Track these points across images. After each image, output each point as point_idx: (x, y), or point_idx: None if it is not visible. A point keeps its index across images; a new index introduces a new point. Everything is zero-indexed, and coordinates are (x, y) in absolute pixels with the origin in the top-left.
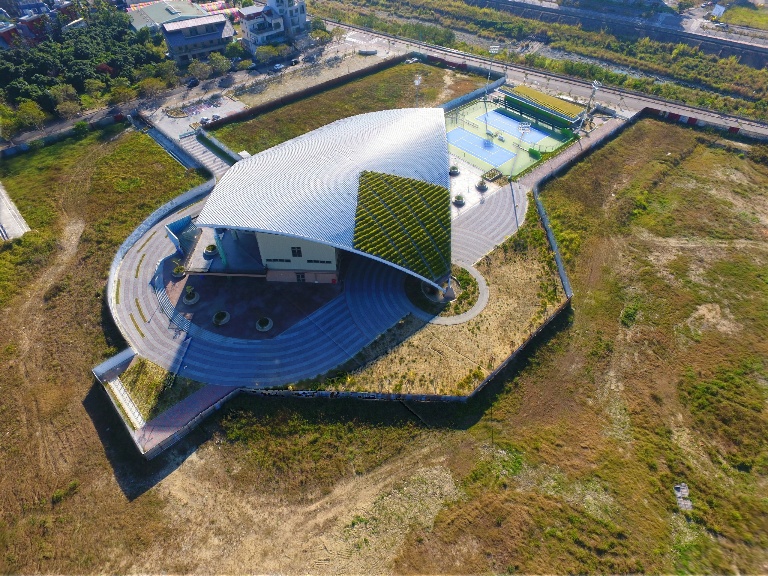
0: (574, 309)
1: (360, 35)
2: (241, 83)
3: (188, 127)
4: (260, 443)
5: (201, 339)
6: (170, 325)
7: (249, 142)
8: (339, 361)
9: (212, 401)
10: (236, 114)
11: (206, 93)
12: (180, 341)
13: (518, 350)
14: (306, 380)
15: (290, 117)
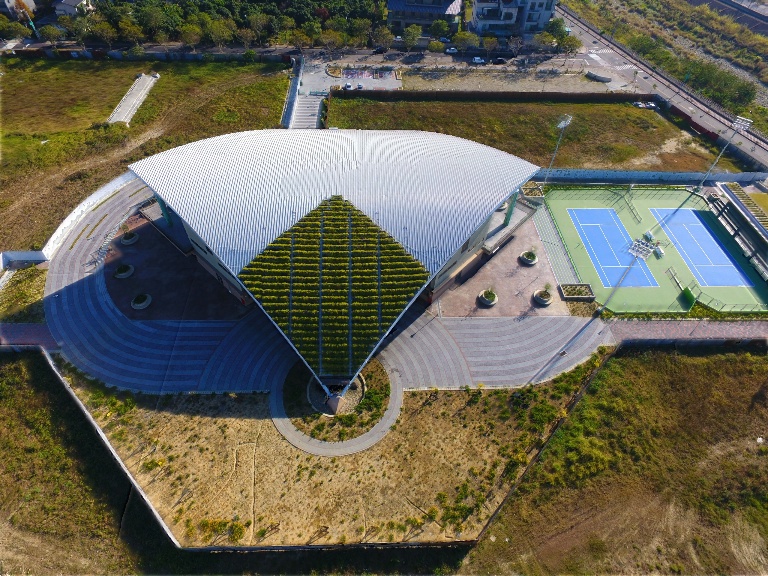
0: (468, 561)
1: (613, 56)
2: (423, 64)
3: (328, 87)
4: (3, 411)
5: (95, 280)
6: (95, 252)
7: (360, 122)
8: (146, 388)
9: (28, 341)
10: (377, 91)
11: (381, 62)
12: (82, 271)
13: (313, 547)
14: (100, 383)
15: (425, 114)
